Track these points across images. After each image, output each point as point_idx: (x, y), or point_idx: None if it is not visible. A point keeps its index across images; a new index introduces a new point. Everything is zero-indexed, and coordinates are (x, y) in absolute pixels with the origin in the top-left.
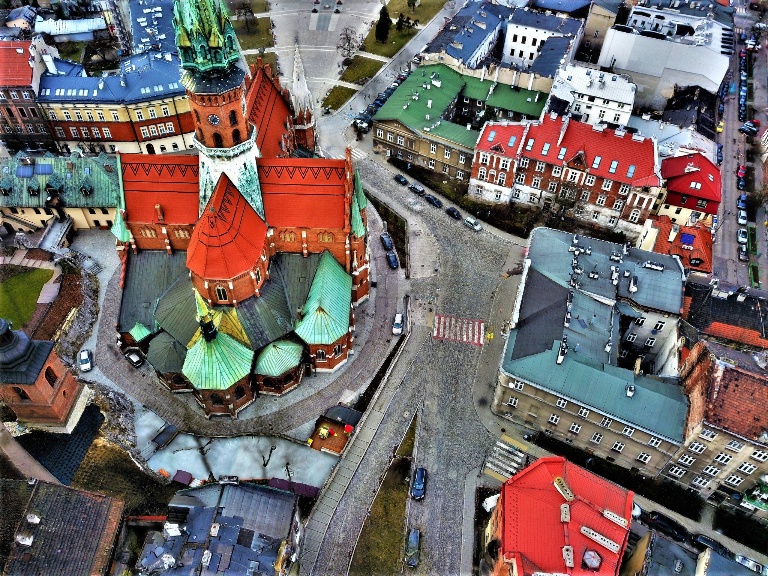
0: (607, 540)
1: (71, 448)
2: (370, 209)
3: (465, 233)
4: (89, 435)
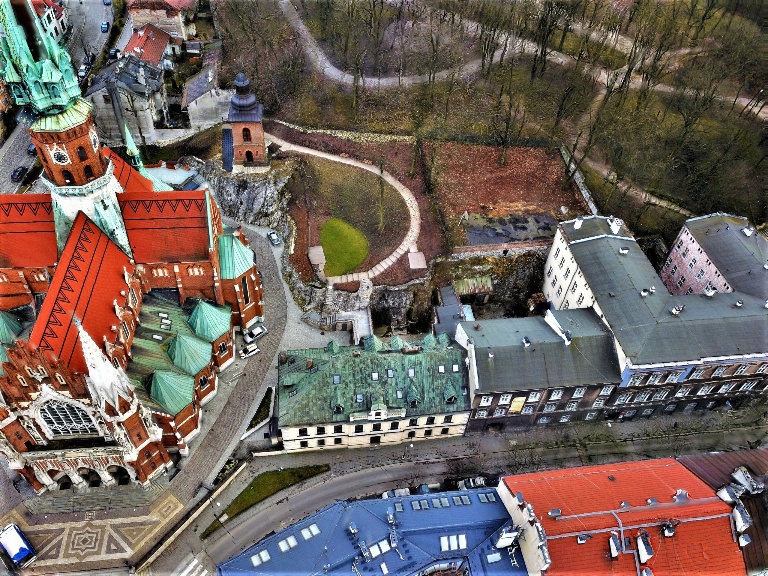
0: None
1: (231, 145)
2: None
3: None
4: (226, 156)
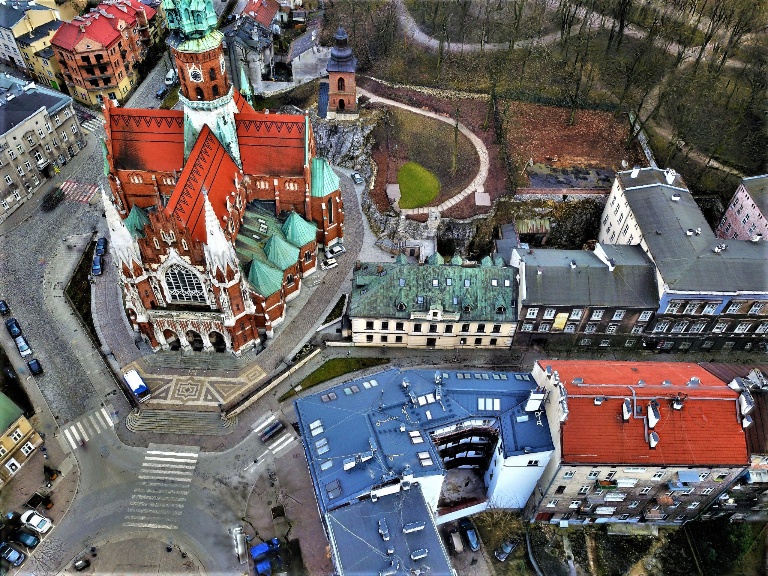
0: (77, 17)
1: (326, 96)
2: (98, 311)
3: (7, 284)
4: (321, 105)
